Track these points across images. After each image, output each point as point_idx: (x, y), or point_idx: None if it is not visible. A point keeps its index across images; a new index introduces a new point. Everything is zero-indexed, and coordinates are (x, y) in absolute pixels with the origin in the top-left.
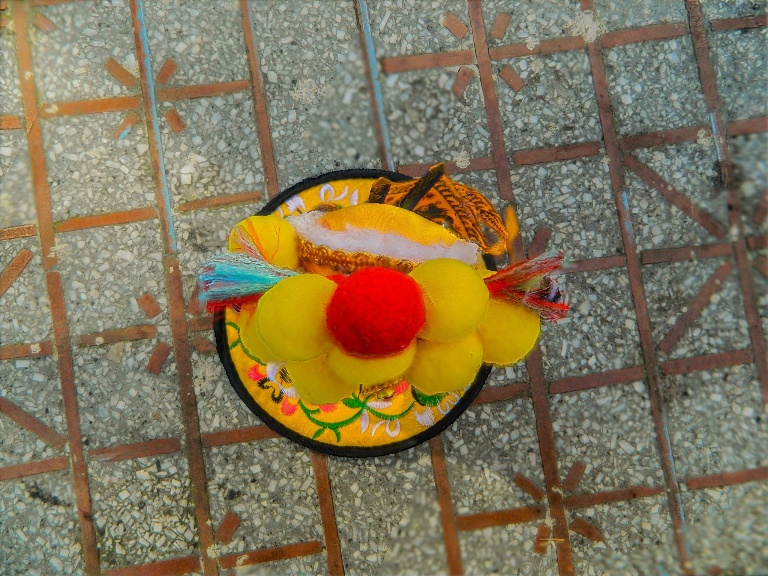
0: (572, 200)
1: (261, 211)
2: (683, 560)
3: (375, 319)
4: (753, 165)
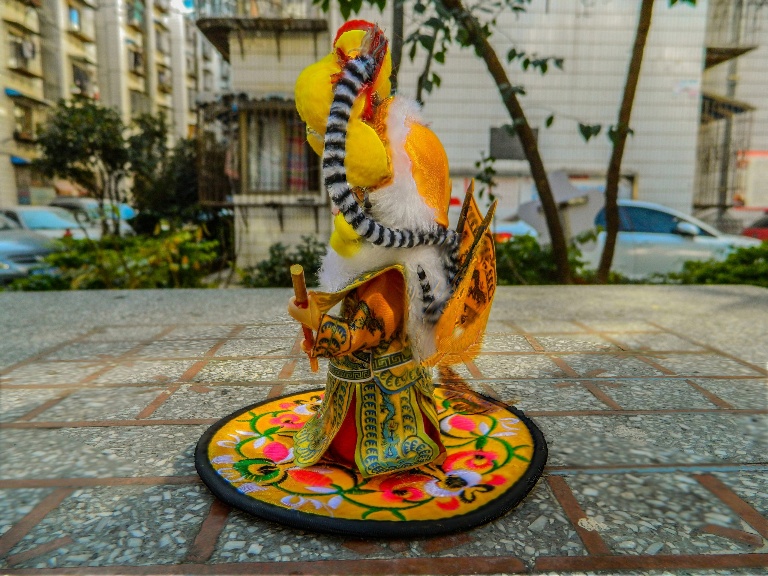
0: None
1: None
2: None
3: None
4: None
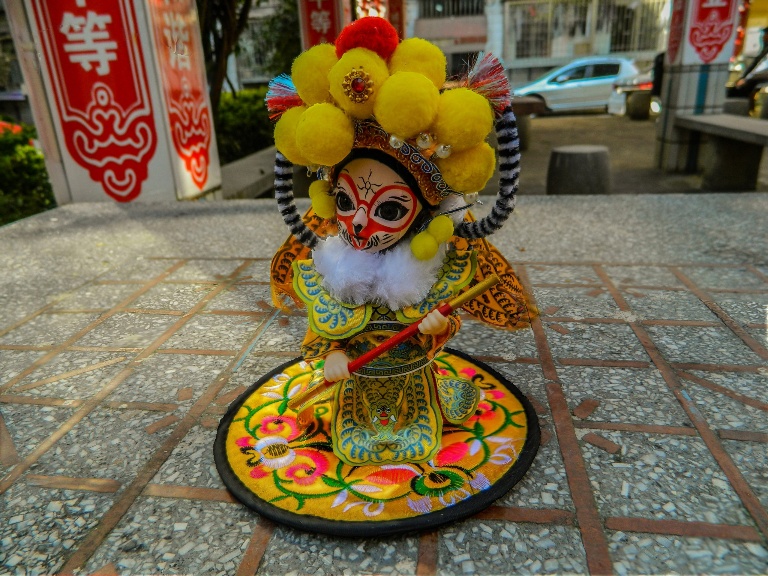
0: (623, 387)
1: None
2: None
3: None
4: None
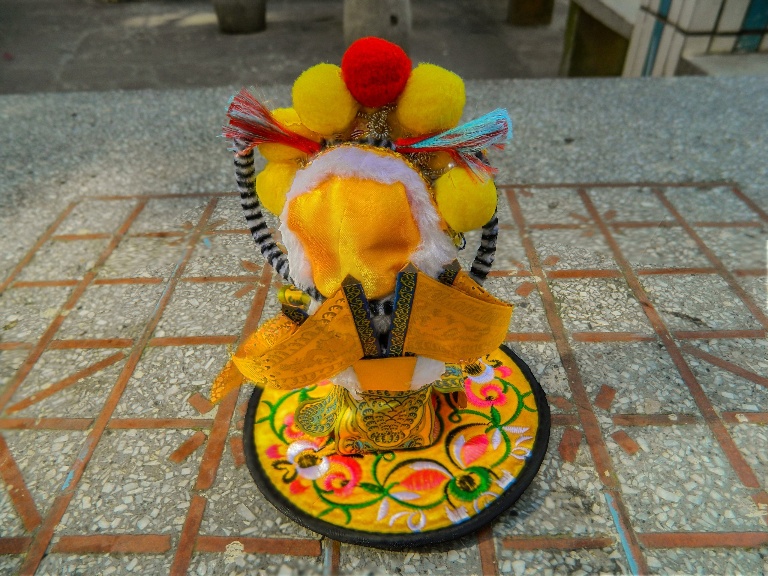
0: (127, 487)
1: (501, 510)
2: (191, 249)
3: (378, 39)
4: None
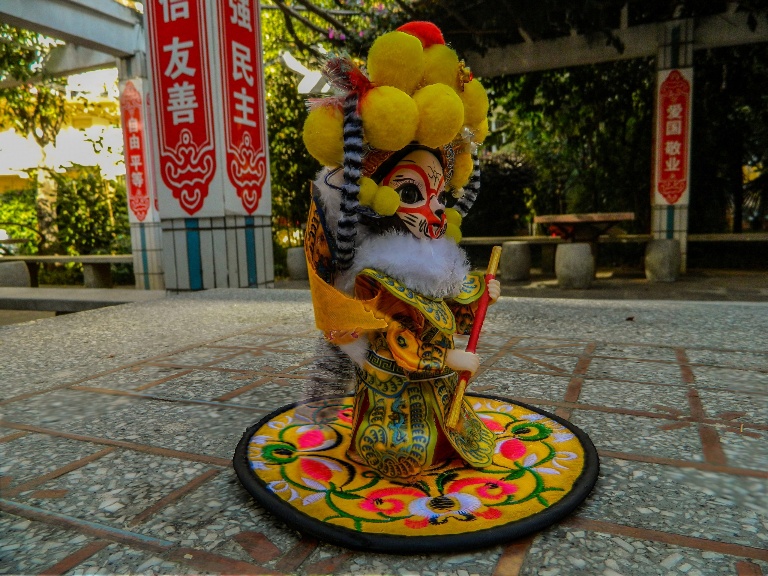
0: None
1: (236, 454)
2: None
3: None
4: (456, 342)
